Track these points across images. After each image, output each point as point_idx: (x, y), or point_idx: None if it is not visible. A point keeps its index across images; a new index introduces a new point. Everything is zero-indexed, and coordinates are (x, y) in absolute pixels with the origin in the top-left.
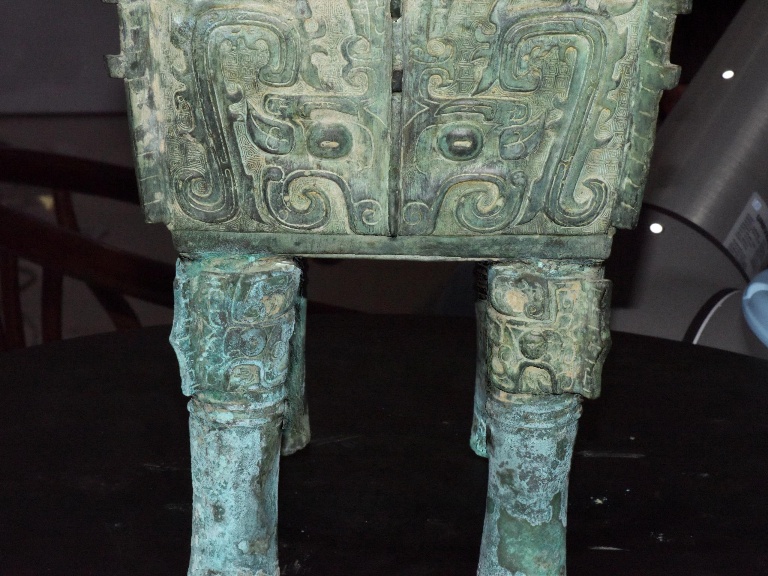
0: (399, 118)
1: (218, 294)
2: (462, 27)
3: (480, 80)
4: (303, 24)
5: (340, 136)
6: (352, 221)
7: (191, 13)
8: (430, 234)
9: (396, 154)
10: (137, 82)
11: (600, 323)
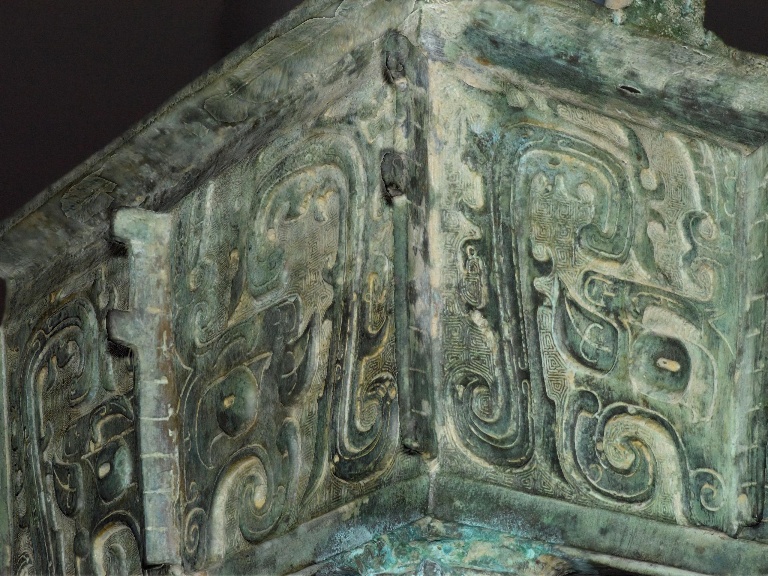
0: None
1: None
2: None
3: None
4: (639, 174)
5: (682, 354)
6: (687, 499)
7: (497, 120)
8: None
9: None
10: (414, 210)
11: None
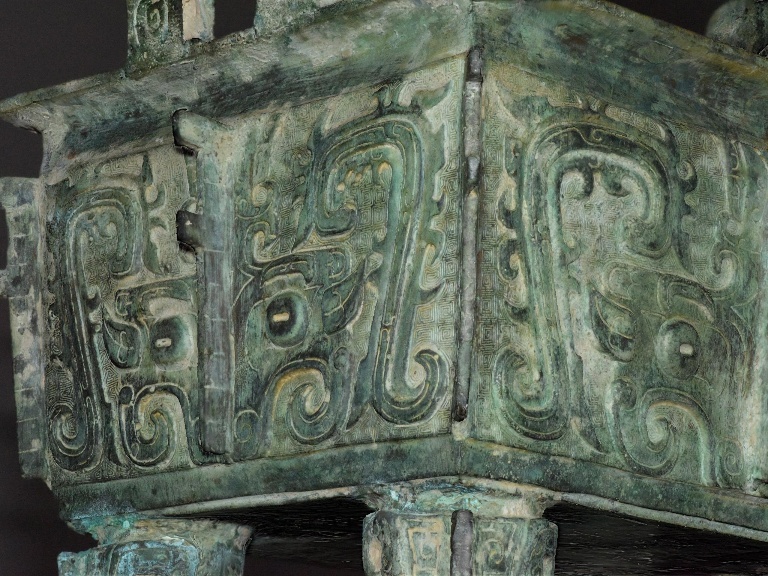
0: (204, 284)
1: (98, 575)
2: (285, 164)
3: (297, 228)
4: (144, 194)
5: (173, 330)
6: (190, 446)
7: (58, 205)
8: (264, 455)
9: (202, 333)
10: (19, 301)
11: (451, 572)
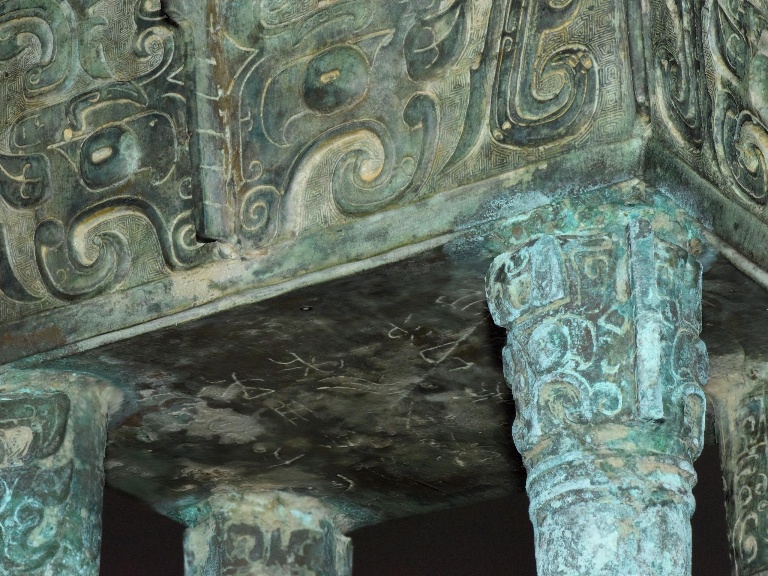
0: None
1: (667, 271)
2: None
3: None
4: None
5: None
6: None
7: None
8: None
9: None
10: None
11: None
